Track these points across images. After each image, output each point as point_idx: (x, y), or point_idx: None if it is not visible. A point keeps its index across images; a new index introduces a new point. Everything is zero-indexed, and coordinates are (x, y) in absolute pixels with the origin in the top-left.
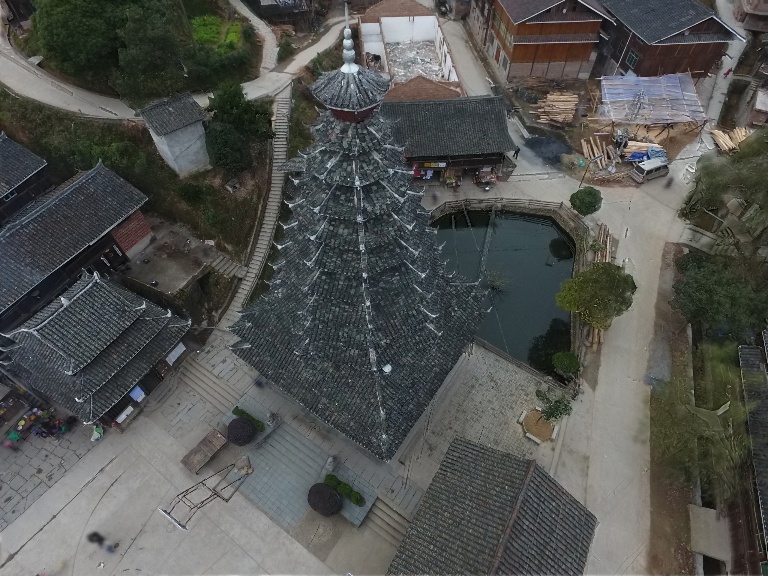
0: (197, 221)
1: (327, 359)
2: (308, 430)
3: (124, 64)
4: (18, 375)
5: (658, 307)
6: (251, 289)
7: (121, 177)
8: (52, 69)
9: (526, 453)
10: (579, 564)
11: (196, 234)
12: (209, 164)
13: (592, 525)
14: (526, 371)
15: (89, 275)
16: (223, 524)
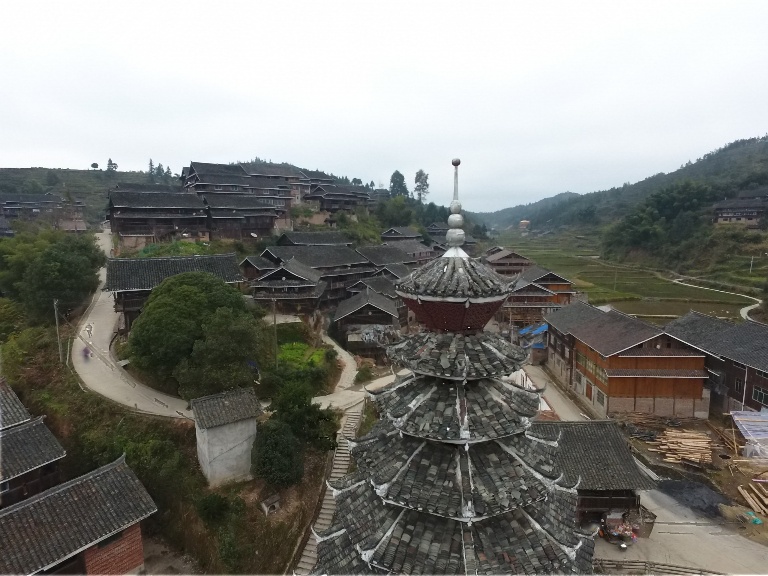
0: (209, 554)
1: None
2: None
3: (196, 355)
4: None
5: None
6: None
7: None
8: (134, 371)
9: None
10: None
11: (201, 575)
12: (250, 474)
13: None
14: None
15: None
16: None
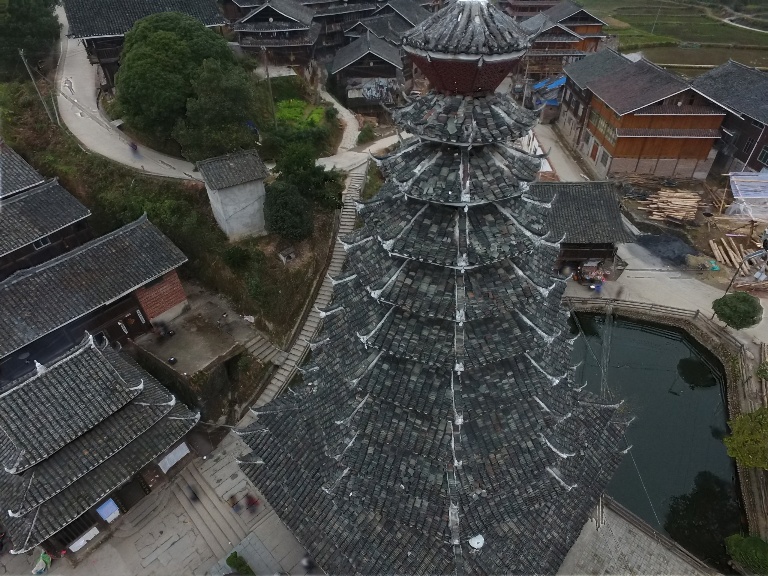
0: (240, 293)
1: (375, 509)
2: None
3: (191, 115)
4: None
5: None
6: (287, 381)
7: (164, 234)
8: (130, 132)
9: None
10: None
11: (236, 308)
12: (265, 230)
13: None
14: (682, 559)
15: None
16: None
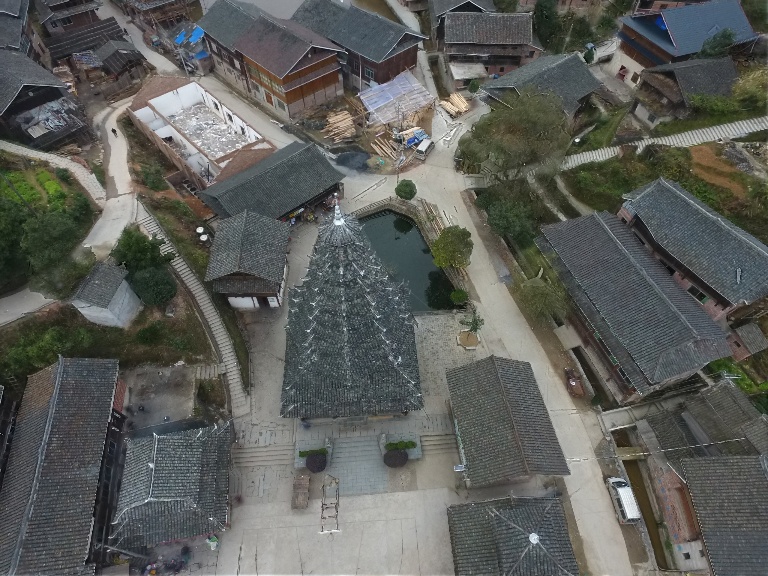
0: (156, 354)
1: (367, 376)
2: (353, 432)
3: (38, 268)
4: (131, 548)
5: (480, 235)
6: (240, 375)
7: None
8: None
9: (473, 358)
10: (536, 387)
11: (161, 364)
12: (140, 306)
13: (529, 367)
14: (442, 314)
15: (132, 442)
16: (347, 519)
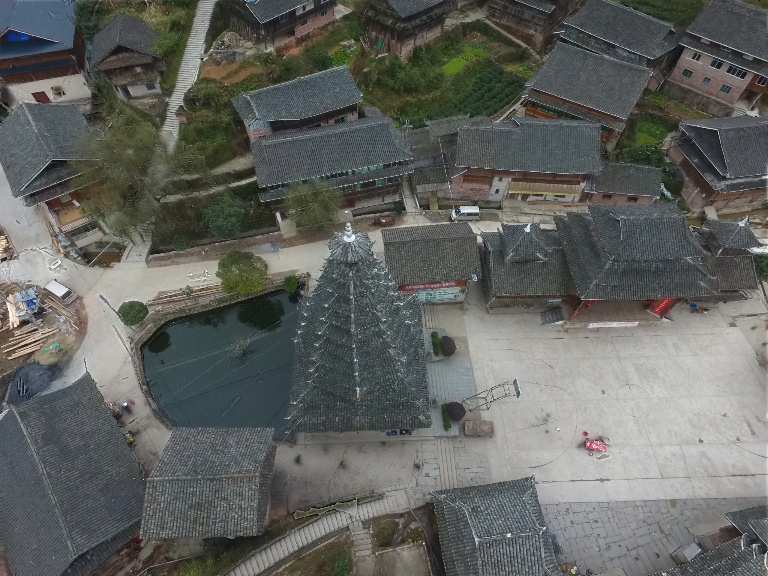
0: None
1: None
2: None
3: None
4: None
5: (216, 259)
6: None
7: None
8: None
9: None
10: None
11: None
12: None
13: None
14: None
15: None
16: None
